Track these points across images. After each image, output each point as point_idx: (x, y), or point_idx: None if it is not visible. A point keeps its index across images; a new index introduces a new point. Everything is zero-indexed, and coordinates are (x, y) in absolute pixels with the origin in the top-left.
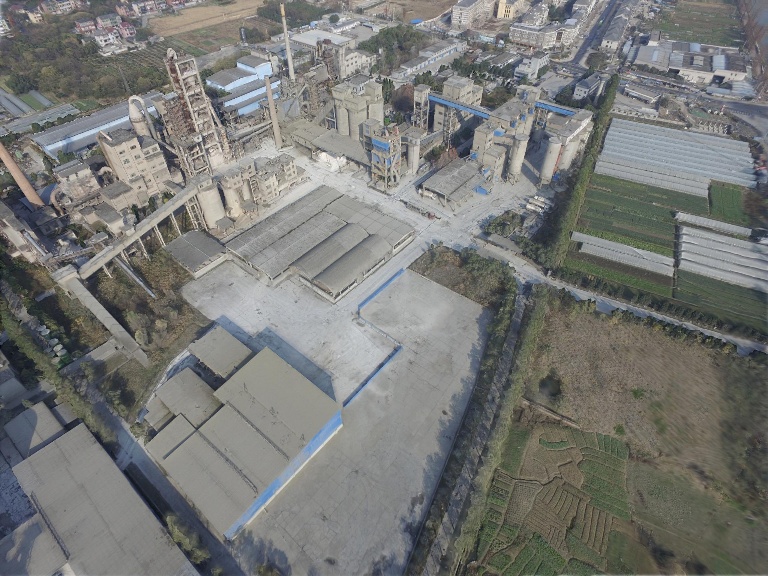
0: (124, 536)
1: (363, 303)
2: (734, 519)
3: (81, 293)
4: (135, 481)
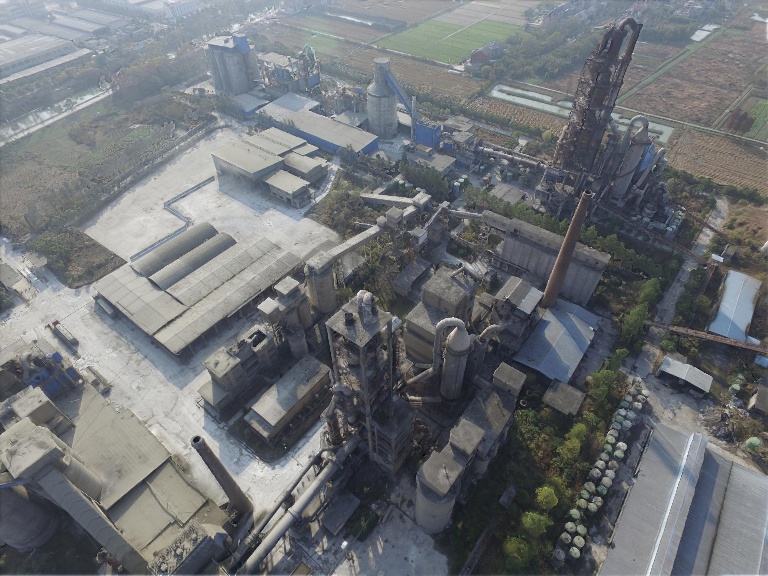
0: (314, 126)
1: (181, 232)
2: (46, 153)
3: (404, 199)
4: (326, 152)
